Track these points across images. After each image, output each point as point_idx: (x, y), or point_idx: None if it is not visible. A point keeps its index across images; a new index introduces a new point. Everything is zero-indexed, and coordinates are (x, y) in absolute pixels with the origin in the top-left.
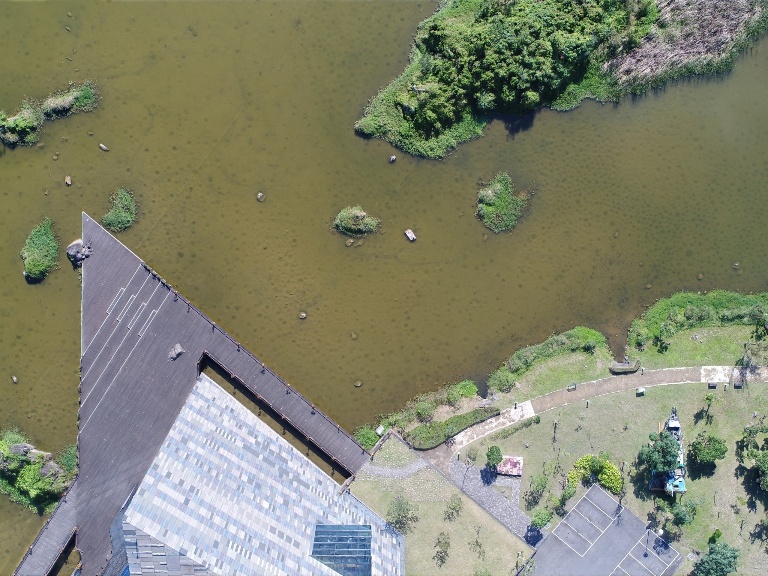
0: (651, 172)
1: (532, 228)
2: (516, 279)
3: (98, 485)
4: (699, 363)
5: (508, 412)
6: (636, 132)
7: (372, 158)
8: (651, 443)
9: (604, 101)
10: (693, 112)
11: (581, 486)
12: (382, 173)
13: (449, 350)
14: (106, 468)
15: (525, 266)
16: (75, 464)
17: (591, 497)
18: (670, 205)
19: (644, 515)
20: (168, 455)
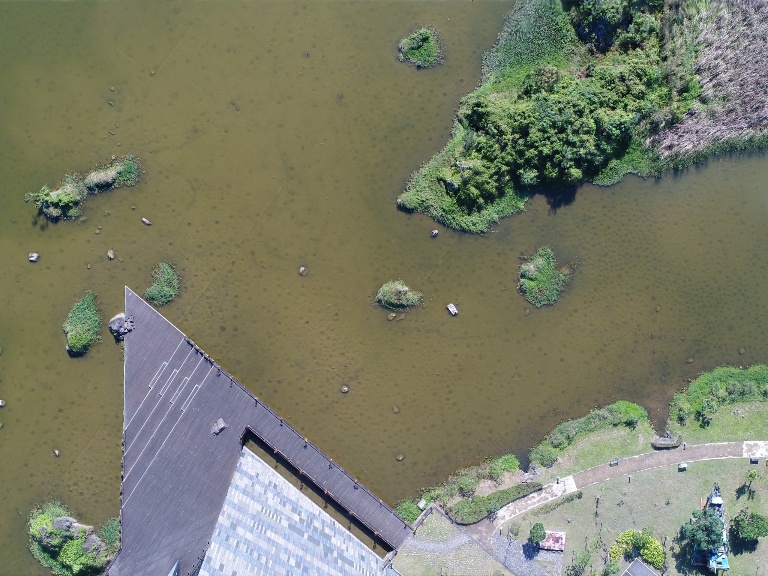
0: (693, 247)
1: (574, 302)
2: (558, 353)
3: (140, 559)
4: (741, 438)
5: (550, 487)
6: (678, 207)
7: (414, 232)
8: (693, 518)
9: (646, 176)
10: (735, 187)
11: (623, 561)
12: (424, 247)
13: (491, 424)
14: (148, 542)
15: (567, 340)
16: (117, 538)
17: (633, 572)
18: (712, 280)
19: None
20: (219, 545)
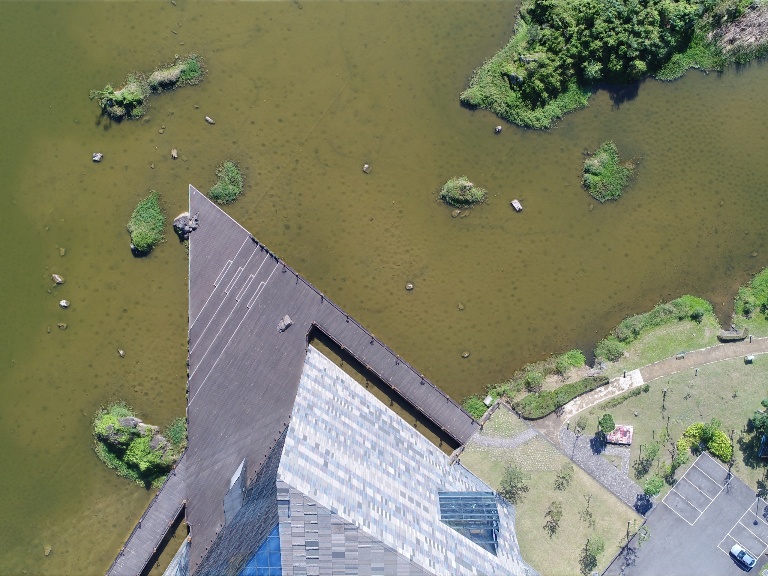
0: (756, 141)
1: (638, 197)
2: (622, 248)
3: (207, 458)
4: None
5: (617, 381)
6: (740, 101)
7: (478, 129)
8: (761, 410)
9: (708, 70)
10: None
11: (690, 454)
12: (488, 144)
13: (556, 320)
14: (215, 441)
15: (631, 235)
16: (183, 437)
17: (700, 465)
18: None
19: (754, 483)
20: (300, 419)
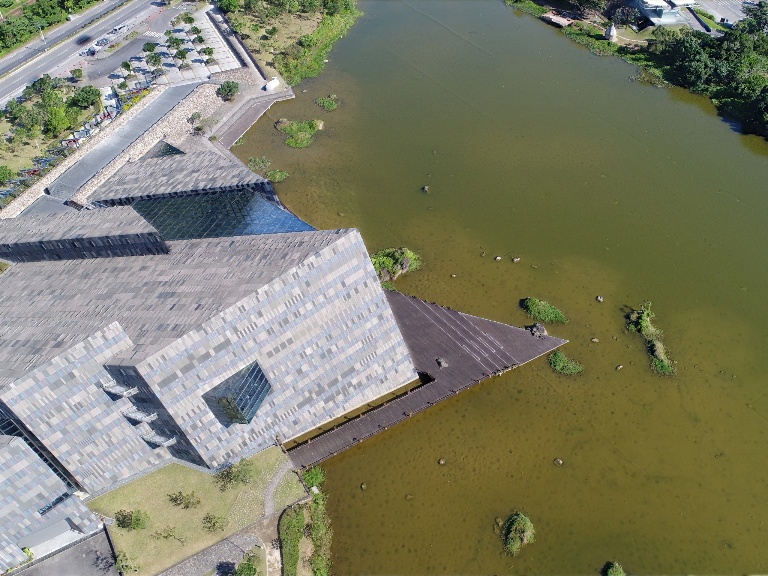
0: None
1: None
2: None
3: None
4: None
5: None
6: None
7: (581, 570)
8: None
9: None
10: None
11: None
12: (564, 574)
13: None
14: None
15: None
16: None
17: None
18: None
19: None
20: (378, 295)
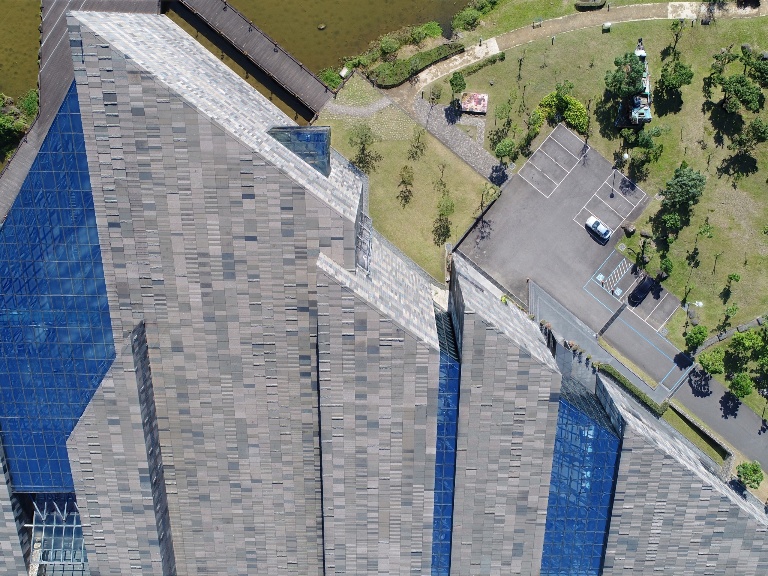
0: None
1: None
2: None
3: None
4: None
5: (473, 49)
6: None
7: None
8: None
9: None
10: None
11: (547, 126)
12: None
13: None
14: None
15: None
16: None
17: (557, 137)
18: None
19: (610, 155)
20: (121, 19)
